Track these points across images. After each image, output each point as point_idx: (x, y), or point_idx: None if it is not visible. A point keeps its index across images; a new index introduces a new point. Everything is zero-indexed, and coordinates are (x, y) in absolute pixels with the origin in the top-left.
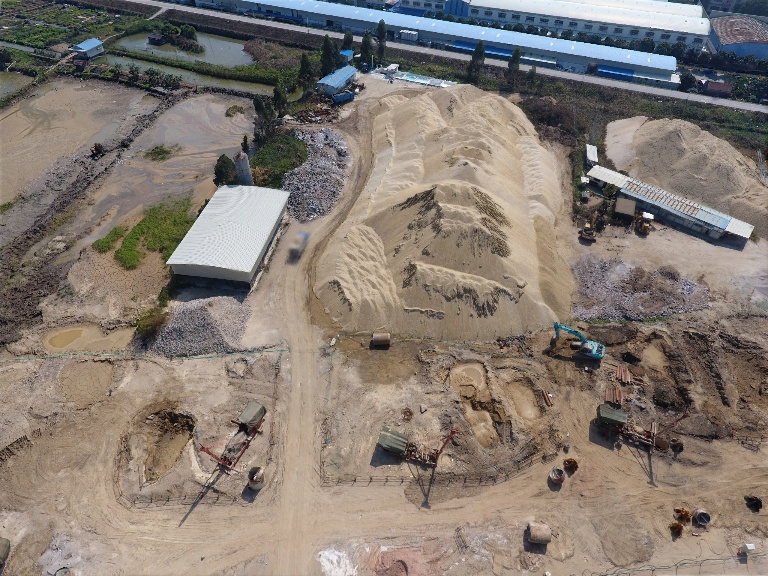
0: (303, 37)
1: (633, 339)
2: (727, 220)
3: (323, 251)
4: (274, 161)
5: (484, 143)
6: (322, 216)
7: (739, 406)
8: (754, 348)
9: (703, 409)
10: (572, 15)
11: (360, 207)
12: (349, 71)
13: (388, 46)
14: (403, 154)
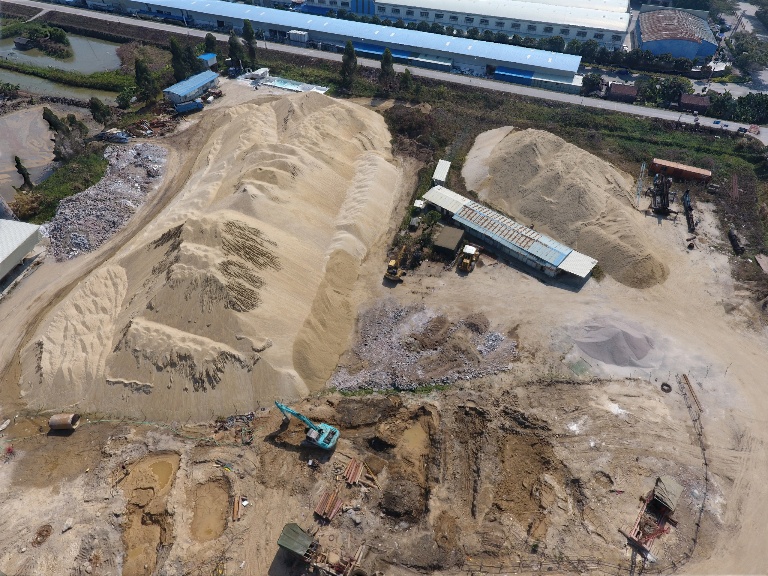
0: (182, 39)
1: (391, 417)
2: (563, 254)
3: (62, 298)
4: (56, 185)
5: (287, 163)
6: (87, 252)
7: (489, 517)
8: (543, 429)
9: (436, 524)
10: (482, 11)
11: (131, 241)
12: (207, 77)
13: (270, 48)
14: (209, 175)
